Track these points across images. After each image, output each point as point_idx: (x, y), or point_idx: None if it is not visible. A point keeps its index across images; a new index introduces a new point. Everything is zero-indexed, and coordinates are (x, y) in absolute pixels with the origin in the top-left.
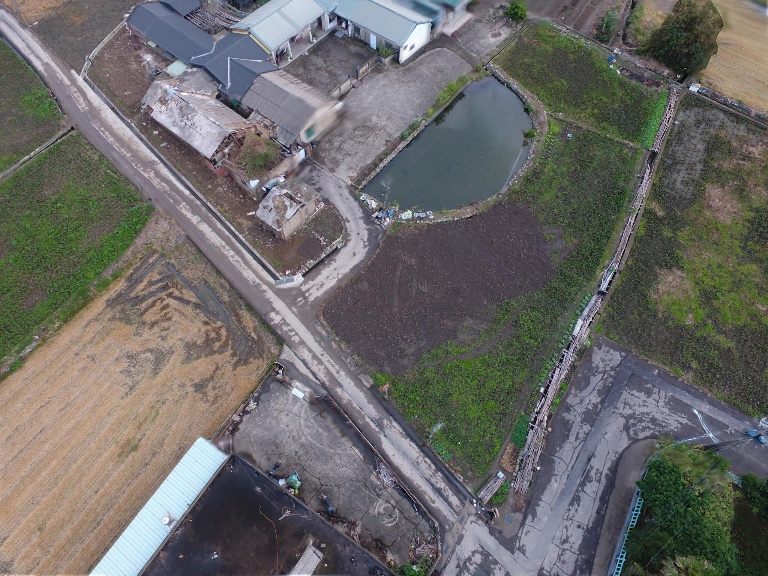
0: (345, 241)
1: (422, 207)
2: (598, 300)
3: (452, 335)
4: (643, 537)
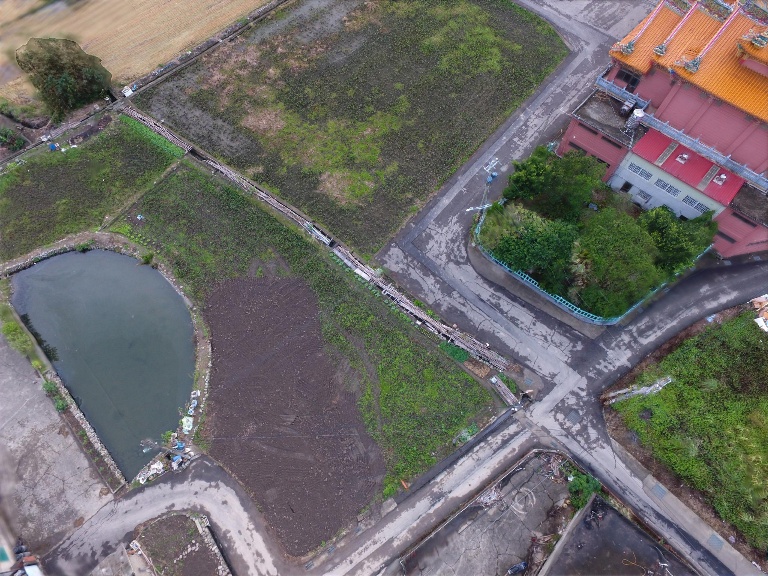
0: (201, 514)
1: (183, 402)
2: (339, 249)
3: (351, 398)
4: (551, 279)
